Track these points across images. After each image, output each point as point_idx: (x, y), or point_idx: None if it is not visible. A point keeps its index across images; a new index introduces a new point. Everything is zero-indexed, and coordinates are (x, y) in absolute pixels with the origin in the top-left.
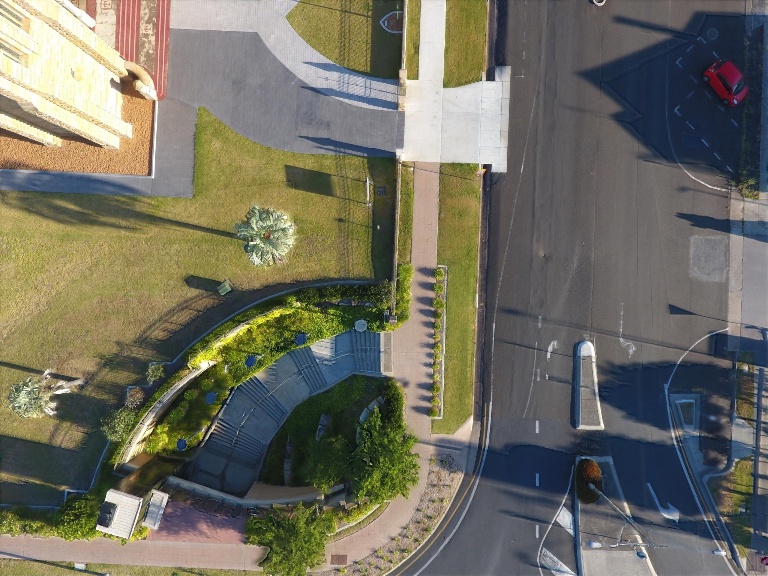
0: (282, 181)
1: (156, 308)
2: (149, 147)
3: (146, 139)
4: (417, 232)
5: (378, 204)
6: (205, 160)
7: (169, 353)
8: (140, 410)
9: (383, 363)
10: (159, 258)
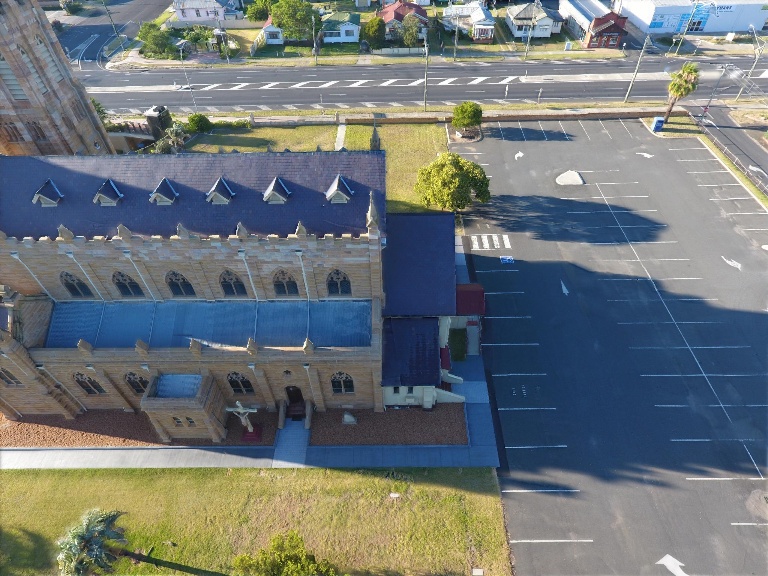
0: None
1: None
2: None
3: None
4: None
5: None
6: None
7: None
8: None
9: None
10: None
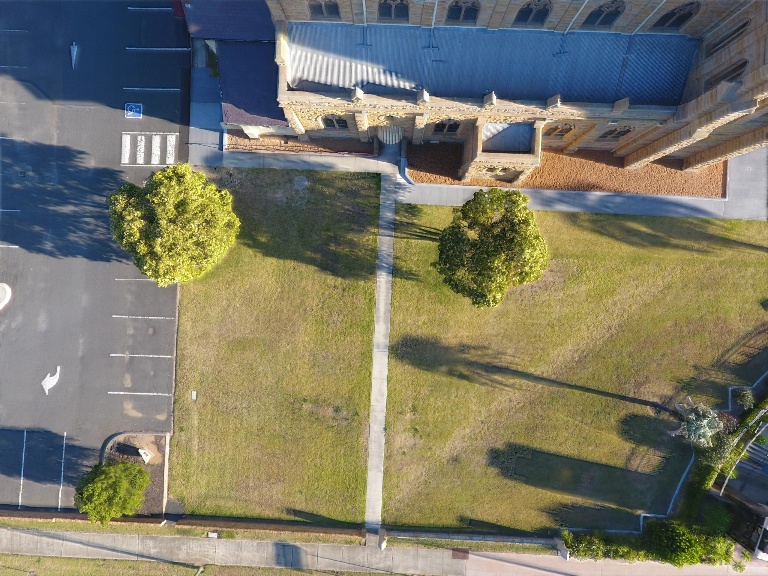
0: None
1: (733, 332)
2: (722, 169)
3: None
4: None
5: None
6: None
7: (749, 377)
8: (732, 435)
9: None
10: (734, 281)
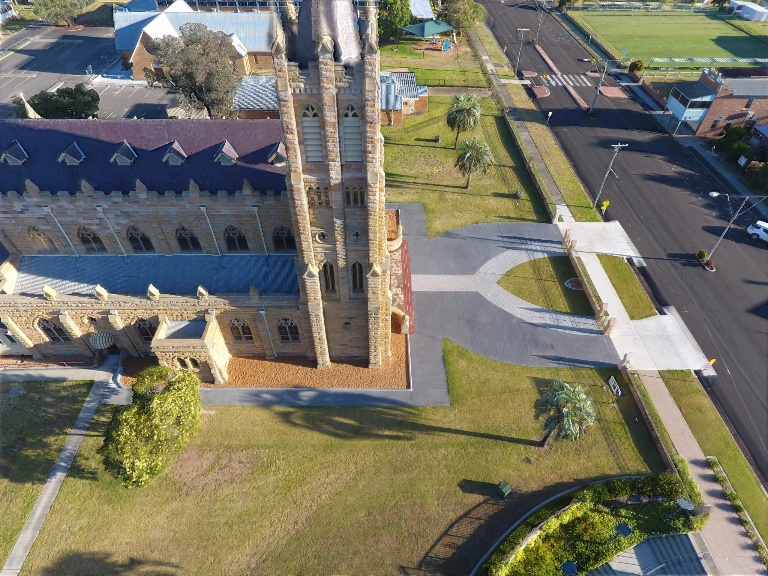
0: (528, 389)
1: (431, 518)
2: (405, 367)
3: (402, 361)
4: (669, 426)
5: (621, 404)
6: (456, 375)
7: (456, 575)
8: None
9: (710, 573)
10: (427, 463)
